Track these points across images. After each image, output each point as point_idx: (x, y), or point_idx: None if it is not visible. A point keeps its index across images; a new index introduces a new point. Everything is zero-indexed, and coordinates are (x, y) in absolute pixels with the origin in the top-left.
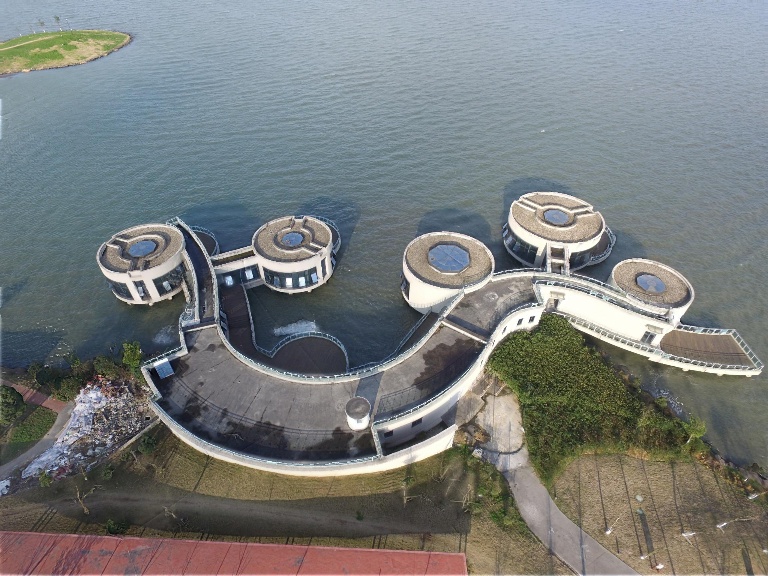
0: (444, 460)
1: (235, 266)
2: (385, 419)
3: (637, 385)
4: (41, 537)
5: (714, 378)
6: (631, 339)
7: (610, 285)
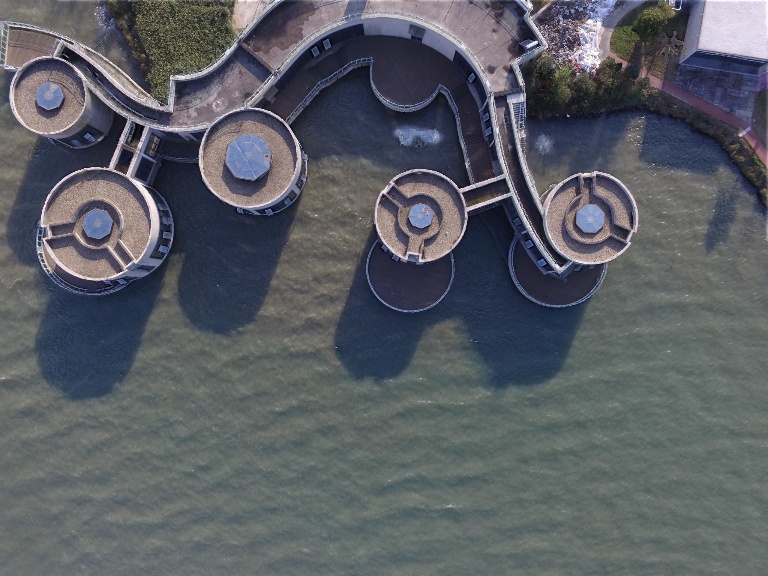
0: None
1: None
2: None
3: None
4: None
5: None
6: None
7: None
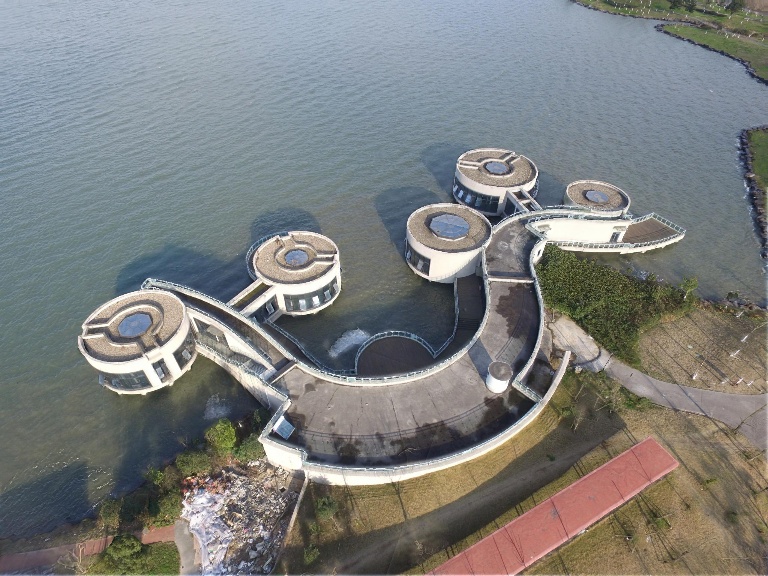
0: (564, 385)
1: (258, 304)
2: None
3: (630, 273)
4: None
5: (661, 251)
6: (603, 243)
7: (576, 206)
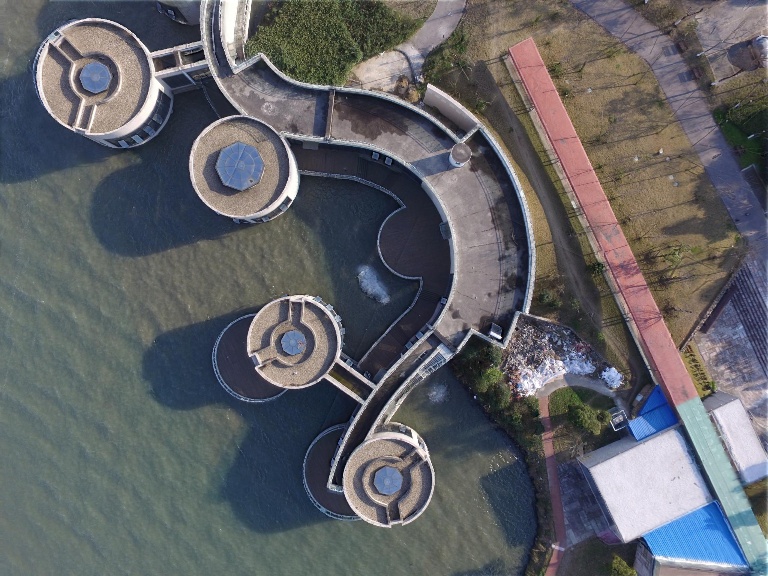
0: None
1: None
2: (454, 134)
3: None
4: (629, 299)
5: None
6: None
7: None
